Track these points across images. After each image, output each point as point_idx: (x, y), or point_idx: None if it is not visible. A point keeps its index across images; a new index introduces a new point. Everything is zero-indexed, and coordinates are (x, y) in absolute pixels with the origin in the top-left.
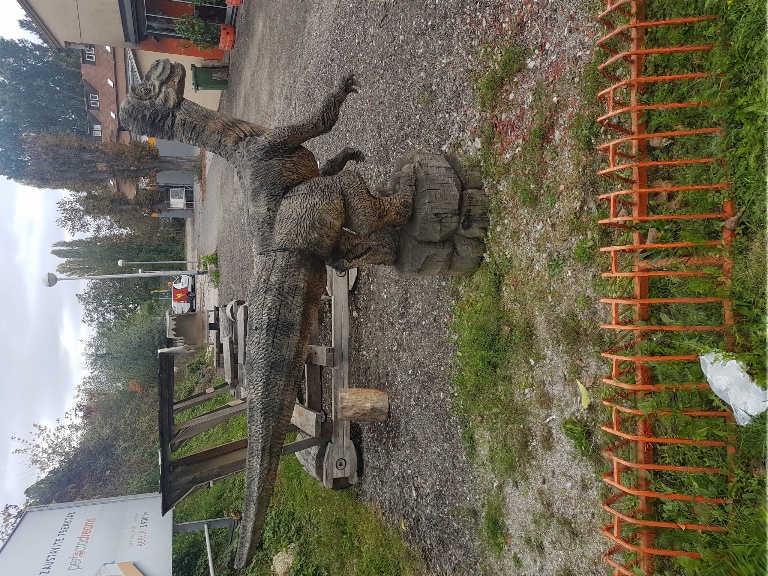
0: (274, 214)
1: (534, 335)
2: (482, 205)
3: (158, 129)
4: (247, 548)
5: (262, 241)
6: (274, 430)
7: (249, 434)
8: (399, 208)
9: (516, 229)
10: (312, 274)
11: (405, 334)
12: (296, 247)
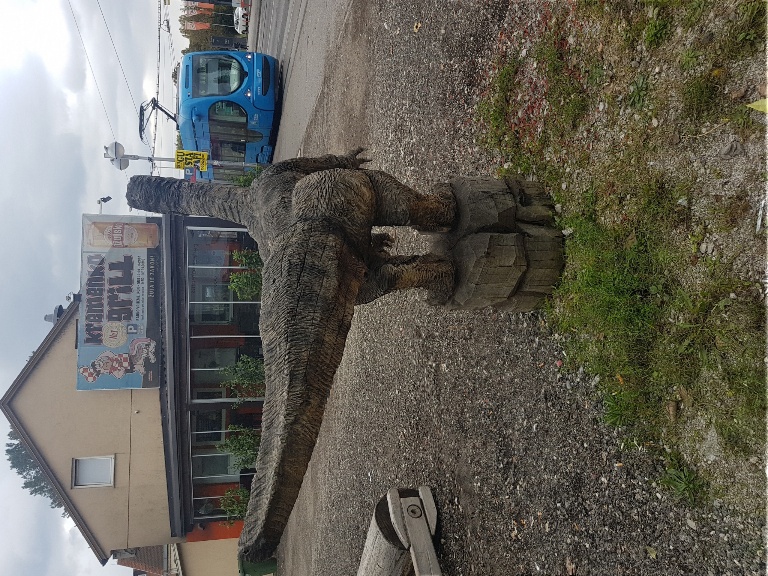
0: (290, 200)
1: (665, 183)
2: (535, 188)
3: (163, 191)
4: (266, 504)
5: (278, 225)
6: (310, 359)
7: (268, 375)
8: (439, 199)
9: (581, 155)
10: (346, 248)
11: (519, 486)
12: (320, 214)
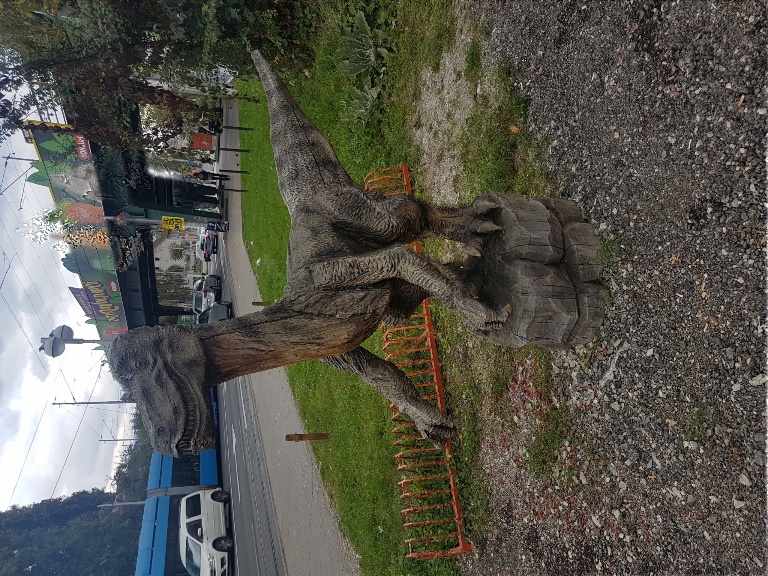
0: None
1: None
2: None
3: None
4: None
5: None
6: None
7: None
8: None
9: None
10: None
11: None
12: None
